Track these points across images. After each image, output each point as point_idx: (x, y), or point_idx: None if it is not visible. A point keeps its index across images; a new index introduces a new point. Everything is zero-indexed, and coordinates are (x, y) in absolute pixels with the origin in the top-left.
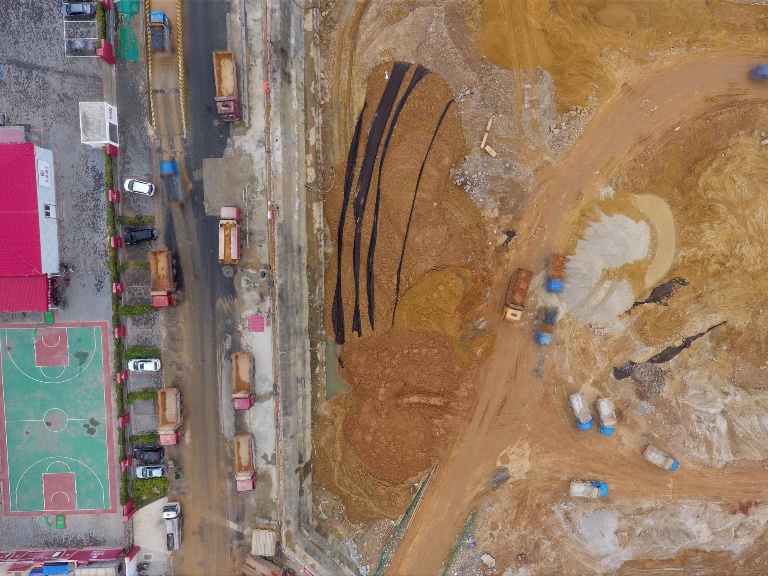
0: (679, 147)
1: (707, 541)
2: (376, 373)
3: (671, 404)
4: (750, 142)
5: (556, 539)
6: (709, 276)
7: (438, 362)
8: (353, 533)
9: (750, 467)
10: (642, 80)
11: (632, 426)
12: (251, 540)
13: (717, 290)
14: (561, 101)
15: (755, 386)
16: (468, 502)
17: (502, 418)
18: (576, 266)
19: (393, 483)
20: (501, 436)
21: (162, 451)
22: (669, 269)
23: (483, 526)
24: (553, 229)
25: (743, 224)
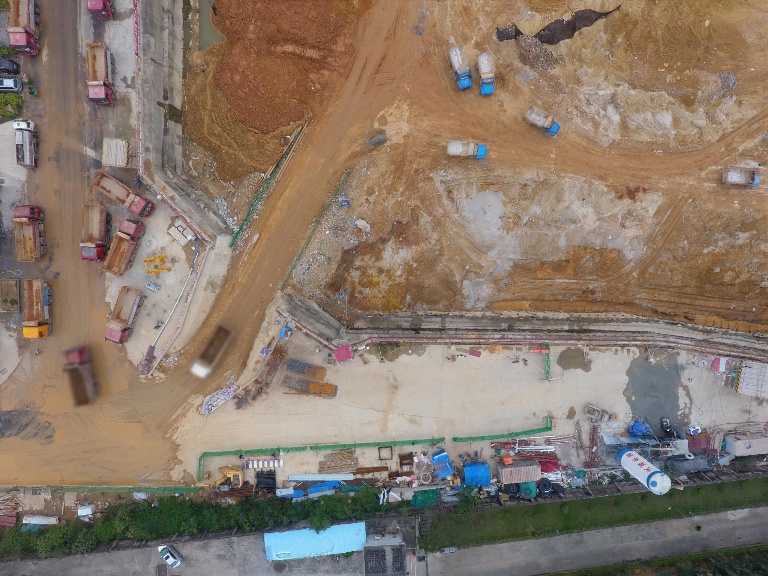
0: None
1: (593, 227)
2: (246, 11)
3: (558, 80)
4: None
5: (437, 217)
6: None
7: (312, 5)
8: (224, 191)
9: (638, 150)
10: None
11: (514, 92)
12: (109, 169)
13: None
14: None
15: (653, 89)
16: (342, 161)
17: (380, 77)
18: None
19: (263, 132)
20: (379, 96)
21: (16, 64)
22: None
23: (358, 189)
24: None
25: None
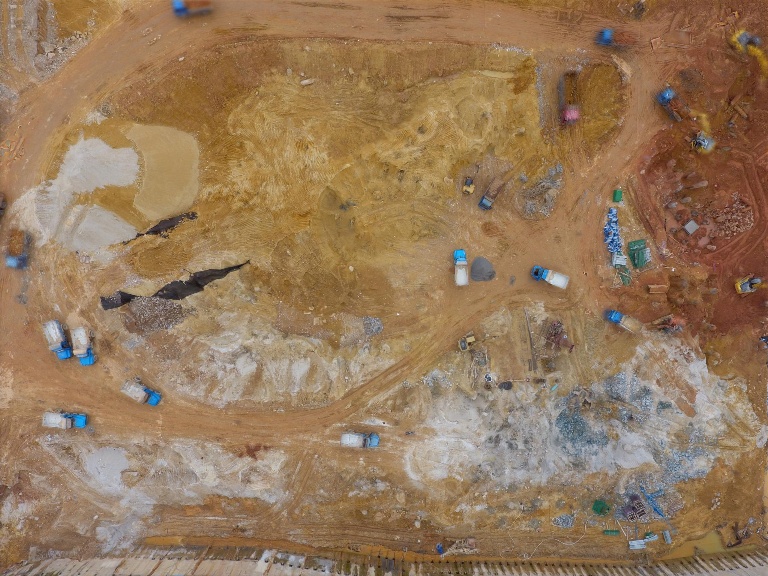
0: (187, 78)
1: (214, 484)
2: None
3: (176, 340)
4: (287, 81)
5: (54, 474)
6: (230, 213)
7: None
8: None
9: (257, 409)
10: (146, 8)
11: (121, 359)
12: None
13: (232, 227)
14: (63, 26)
15: (299, 332)
16: None
17: None
18: (53, 190)
19: None
20: None
21: None
22: (191, 204)
23: None
24: (36, 152)
25: (270, 162)
